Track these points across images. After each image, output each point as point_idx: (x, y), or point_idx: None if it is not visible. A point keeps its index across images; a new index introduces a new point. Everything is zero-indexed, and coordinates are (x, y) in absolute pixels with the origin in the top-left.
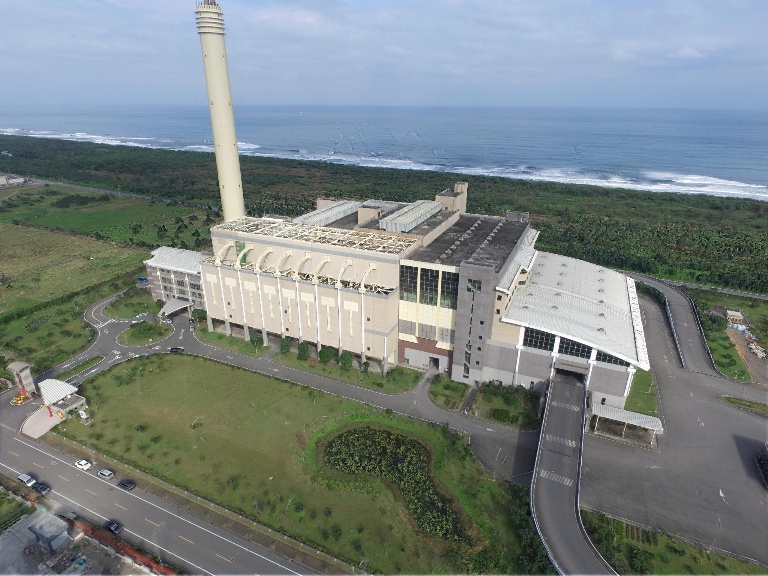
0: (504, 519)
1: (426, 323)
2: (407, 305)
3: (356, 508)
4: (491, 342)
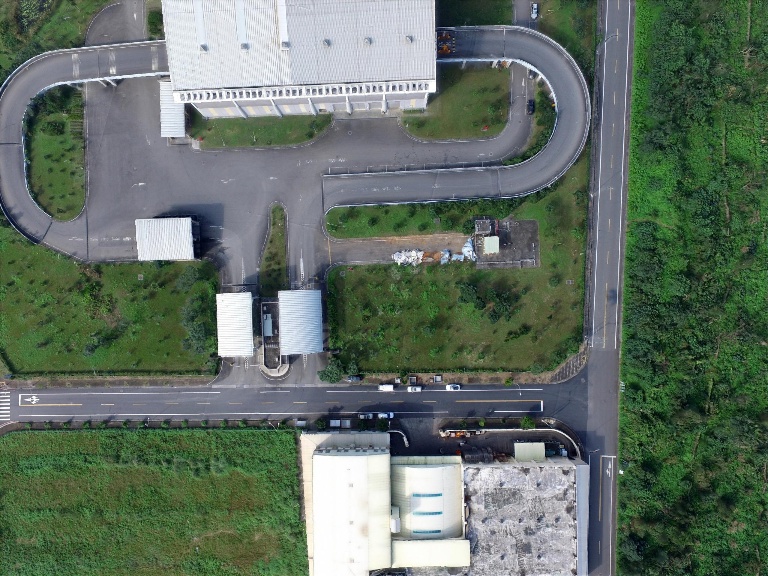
0: None
1: None
2: None
3: None
4: None
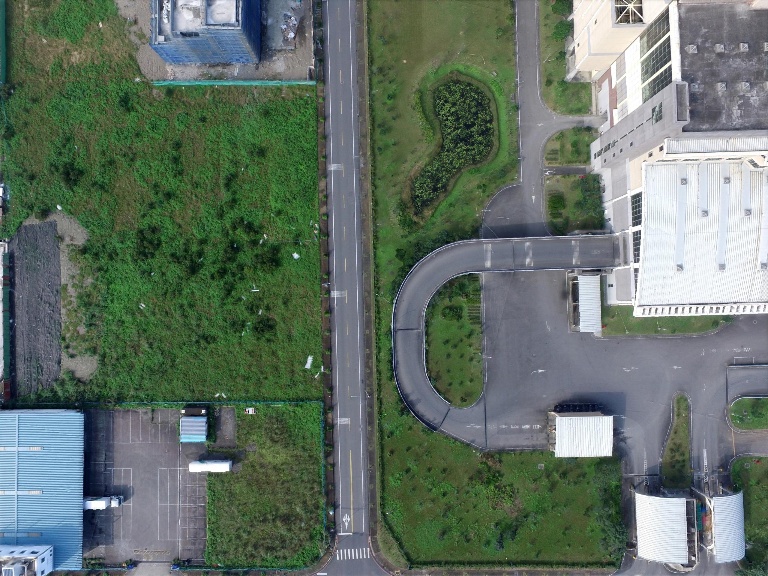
0: (446, 229)
1: (627, 84)
2: (637, 50)
3: (408, 133)
4: (628, 163)
